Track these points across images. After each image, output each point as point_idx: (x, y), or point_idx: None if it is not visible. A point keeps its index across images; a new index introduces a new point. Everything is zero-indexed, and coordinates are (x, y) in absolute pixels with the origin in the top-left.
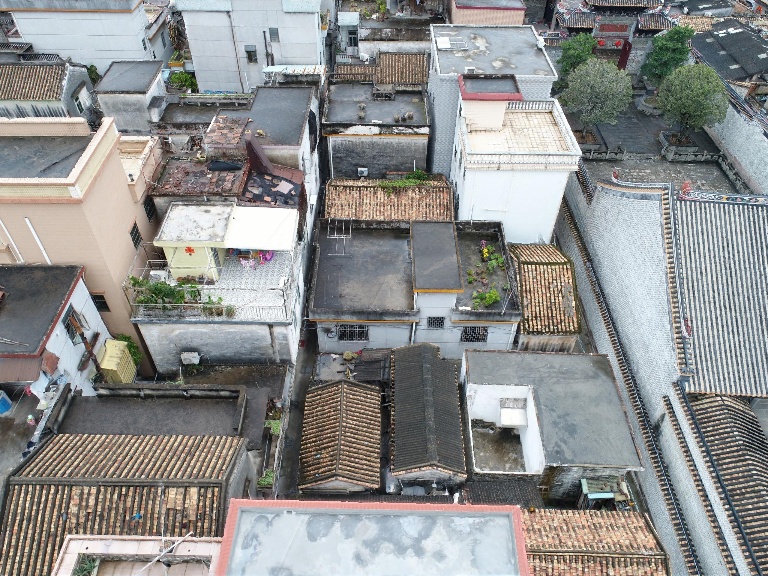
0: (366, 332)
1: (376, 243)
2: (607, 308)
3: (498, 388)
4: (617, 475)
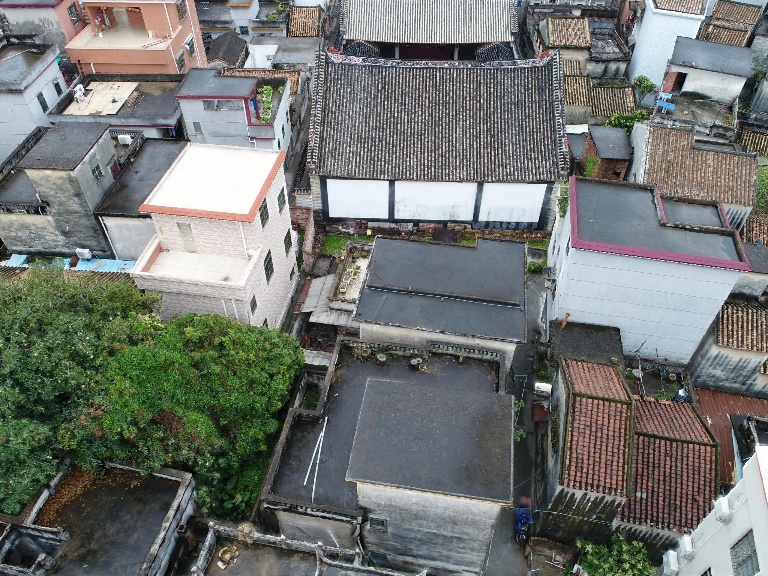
0: (210, 37)
1: (225, 5)
2: (338, 30)
3: (263, 47)
4: (306, 70)
